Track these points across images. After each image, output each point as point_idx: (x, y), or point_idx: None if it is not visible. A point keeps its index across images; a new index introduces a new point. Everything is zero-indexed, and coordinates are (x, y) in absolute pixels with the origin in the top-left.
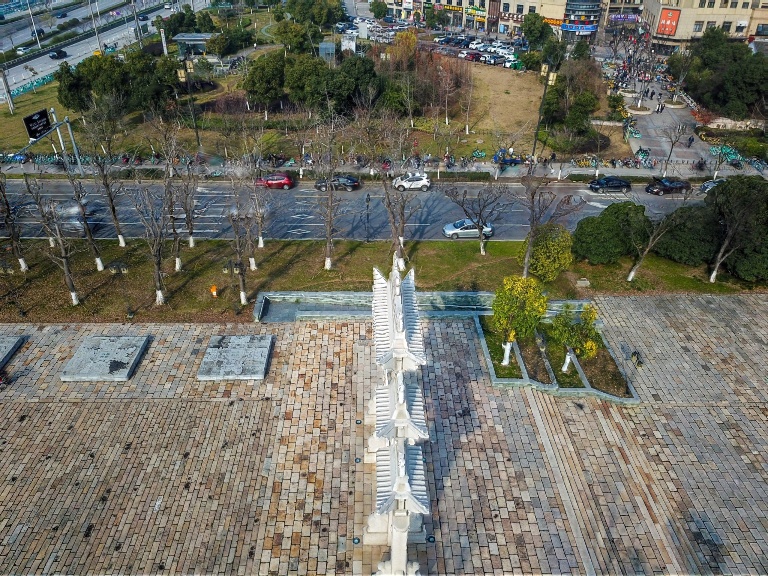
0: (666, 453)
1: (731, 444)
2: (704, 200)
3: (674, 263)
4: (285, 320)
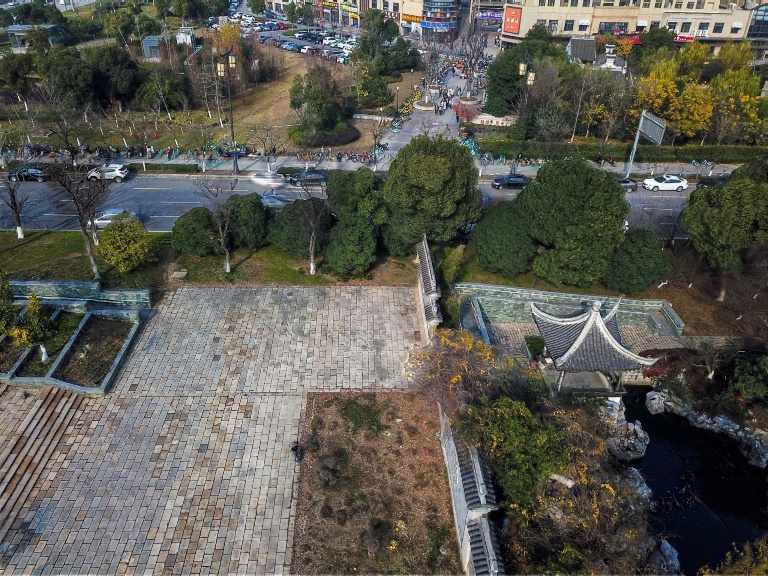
0: (82, 443)
1: (159, 434)
2: None
3: (289, 255)
4: None
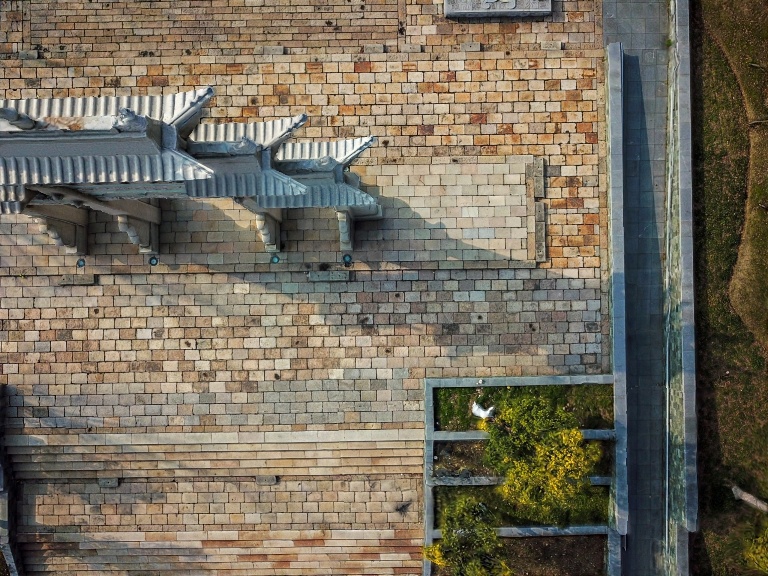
0: None
1: None
2: None
3: None
4: (608, 29)
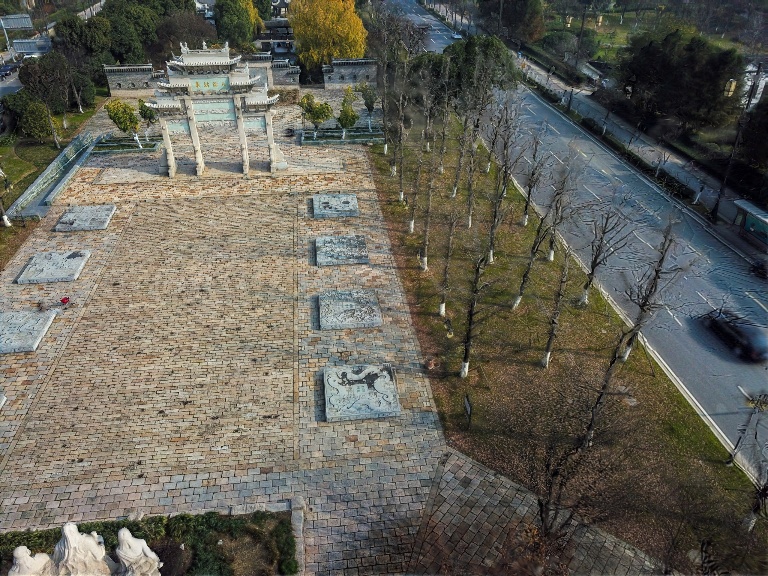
0: None
1: None
2: (23, 81)
3: (58, 116)
4: (47, 209)
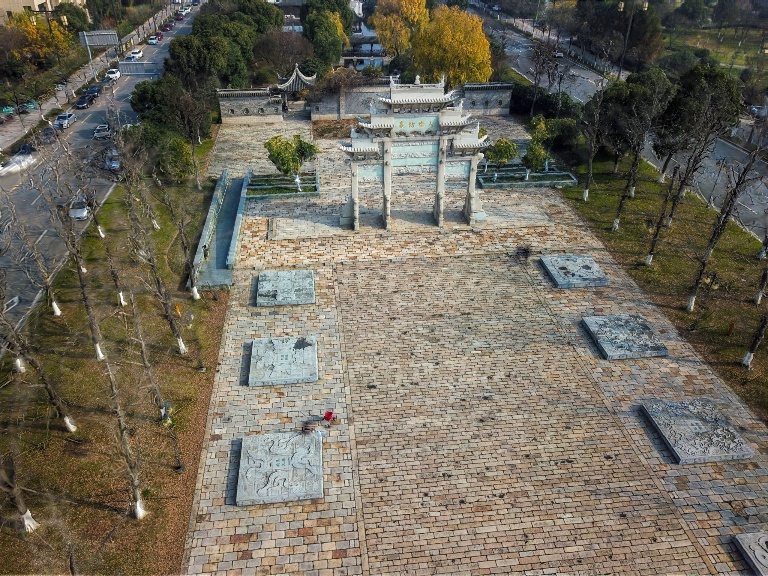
0: None
1: None
2: (137, 108)
3: None
4: (230, 274)
